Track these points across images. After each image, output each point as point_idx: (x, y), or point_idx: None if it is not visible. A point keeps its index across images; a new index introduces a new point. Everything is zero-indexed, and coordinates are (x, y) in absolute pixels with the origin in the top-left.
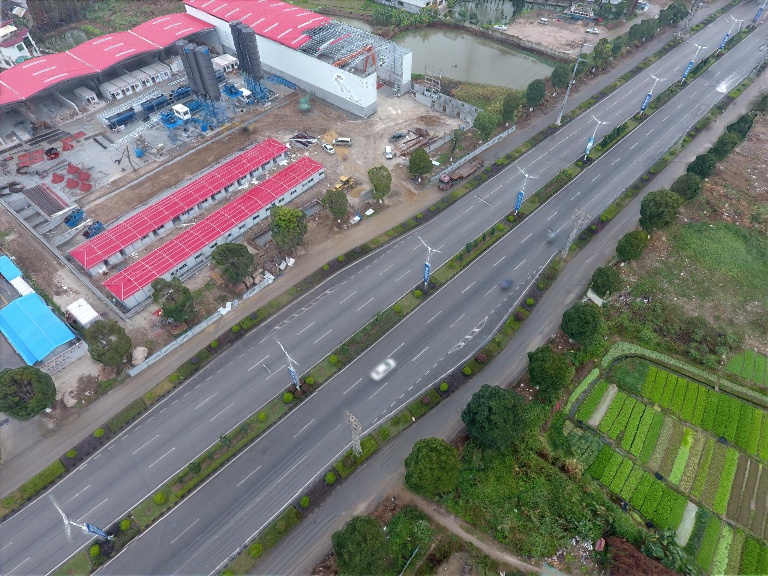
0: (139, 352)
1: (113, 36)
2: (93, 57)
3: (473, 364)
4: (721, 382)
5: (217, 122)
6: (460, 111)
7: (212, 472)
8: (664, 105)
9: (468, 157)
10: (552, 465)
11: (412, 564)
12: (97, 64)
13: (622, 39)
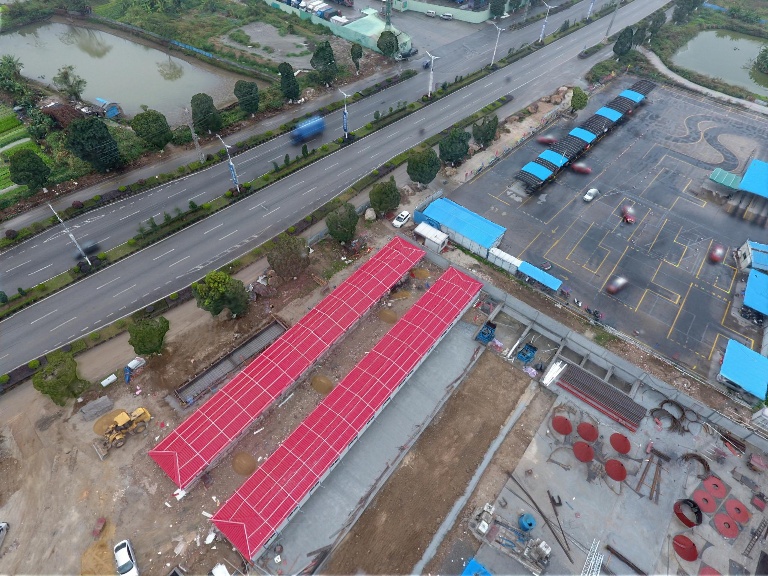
0: (370, 213)
1: None
2: None
3: (88, 203)
4: None
5: None
6: None
7: None
8: None
9: None
10: None
11: None
12: None
13: None
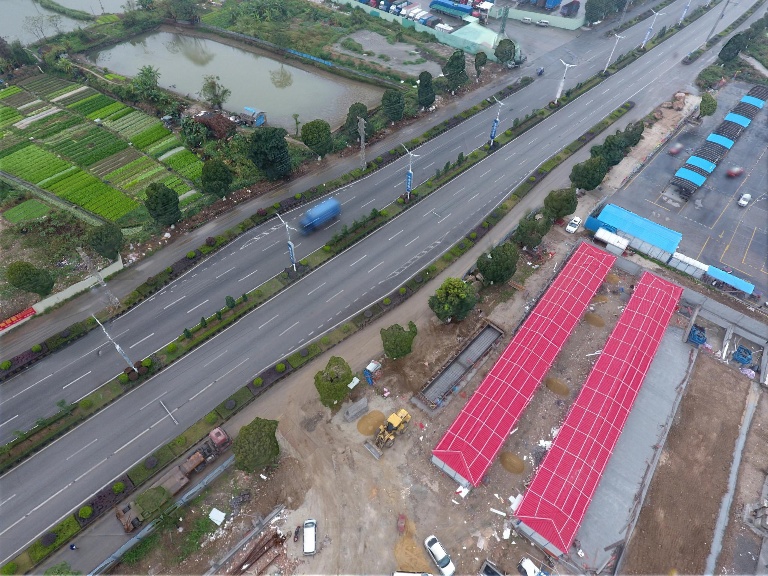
0: None
1: None
2: None
3: (270, 211)
4: (67, 207)
5: None
6: None
7: None
8: None
9: (141, 536)
10: None
11: None
12: None
13: None
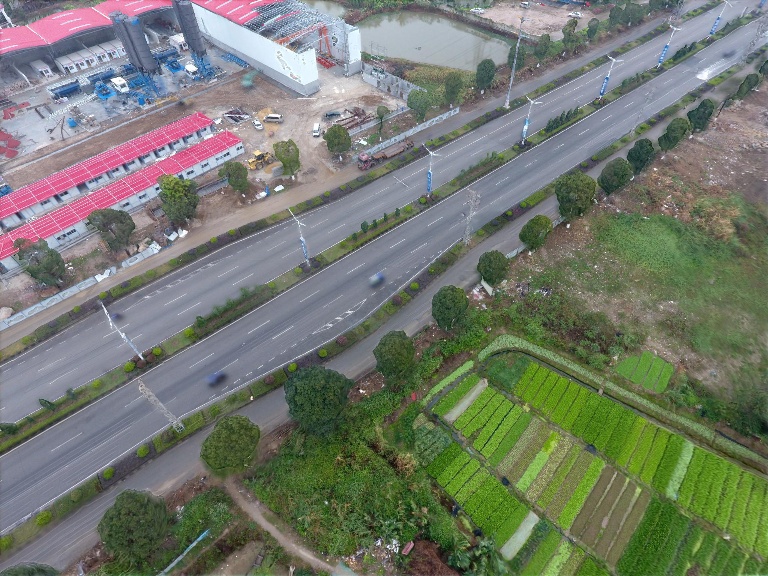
0: (2, 312)
1: (74, 12)
2: (49, 31)
3: (332, 346)
4: (606, 385)
5: (157, 96)
6: (402, 91)
7: (31, 434)
8: (631, 91)
9: (399, 137)
10: (383, 458)
11: (197, 547)
12: (50, 37)
13: (597, 21)
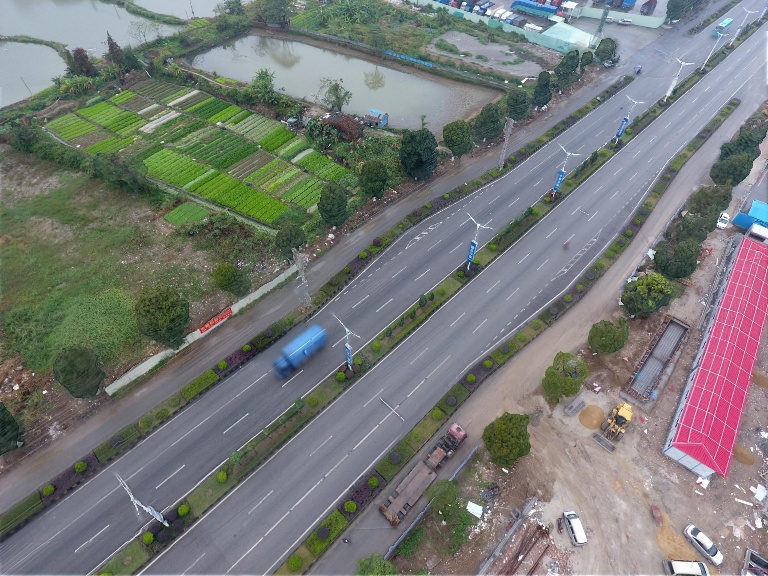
0: None
1: None
2: None
3: (423, 211)
4: (221, 210)
5: None
6: None
7: None
8: None
9: None
10: None
11: None
12: None
13: None
